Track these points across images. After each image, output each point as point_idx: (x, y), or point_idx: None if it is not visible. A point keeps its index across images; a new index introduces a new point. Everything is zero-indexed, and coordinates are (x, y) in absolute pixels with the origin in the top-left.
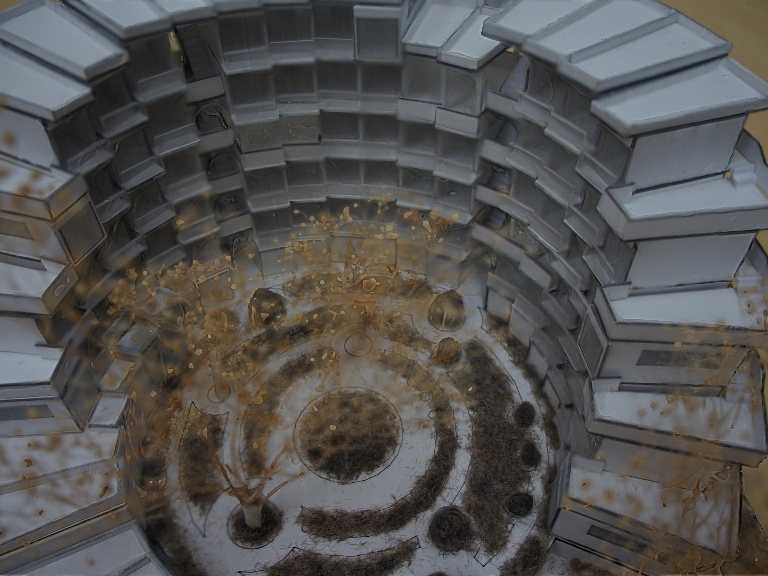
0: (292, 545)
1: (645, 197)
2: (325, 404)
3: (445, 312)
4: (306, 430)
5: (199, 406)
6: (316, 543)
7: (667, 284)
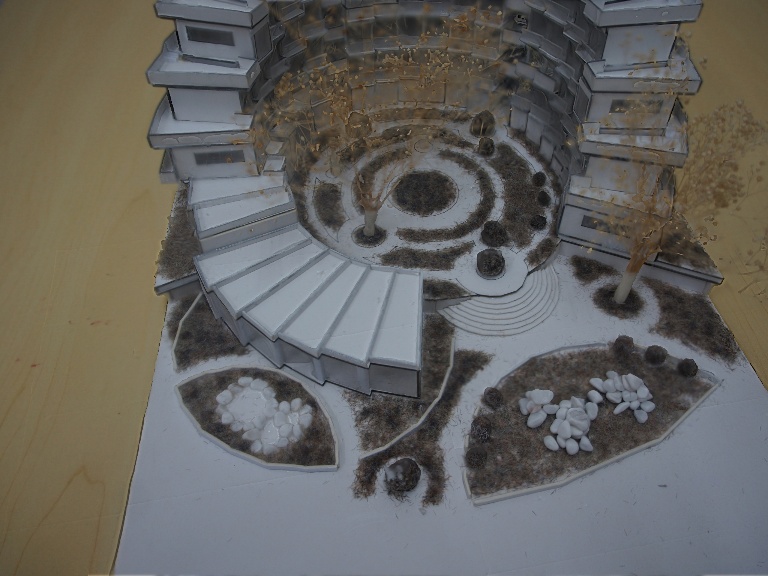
0: (394, 245)
1: (613, 7)
2: (405, 177)
3: (483, 122)
4: (395, 190)
5: (321, 180)
6: (409, 244)
7: (627, 63)
